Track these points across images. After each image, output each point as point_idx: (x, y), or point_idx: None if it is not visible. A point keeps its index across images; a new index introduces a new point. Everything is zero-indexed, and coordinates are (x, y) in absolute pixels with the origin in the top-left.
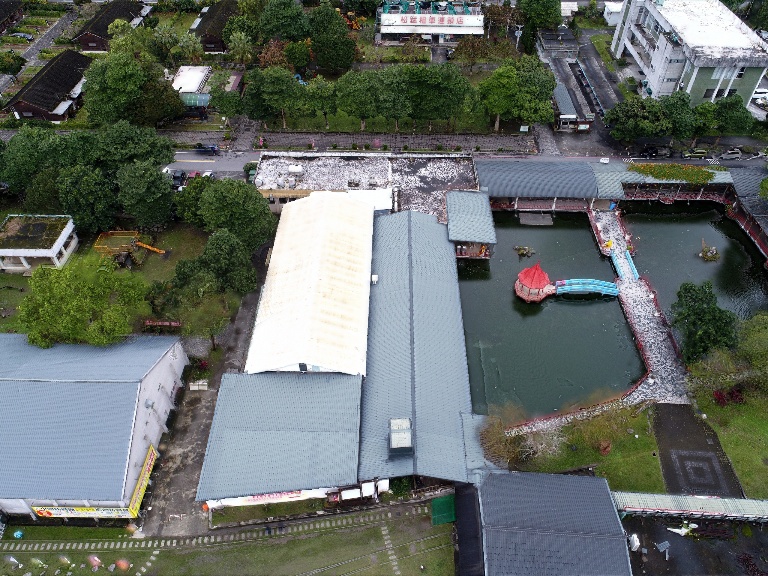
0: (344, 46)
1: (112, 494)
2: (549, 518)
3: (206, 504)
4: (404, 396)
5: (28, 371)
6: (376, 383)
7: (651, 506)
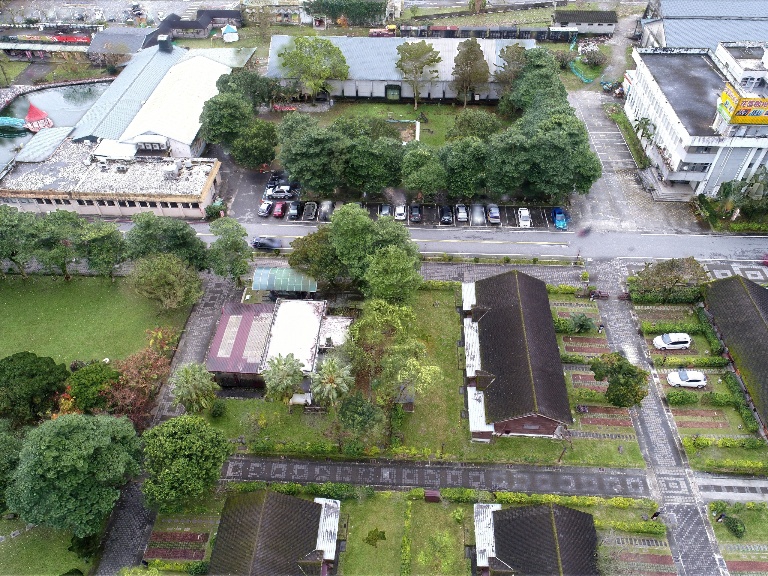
0: (1, 372)
1: None
2: (120, 38)
3: (257, 62)
4: (156, 60)
5: None
6: (167, 69)
7: (76, 47)
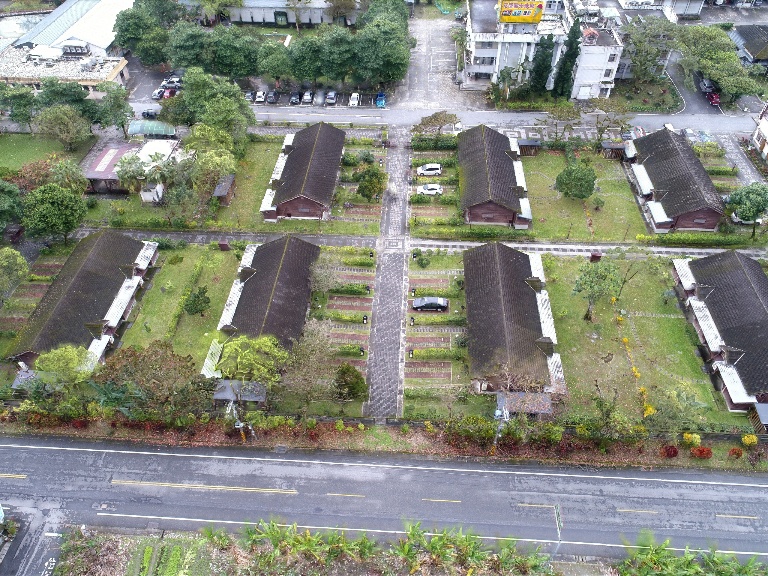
0: None
1: None
2: None
3: None
4: None
5: None
6: None
7: None
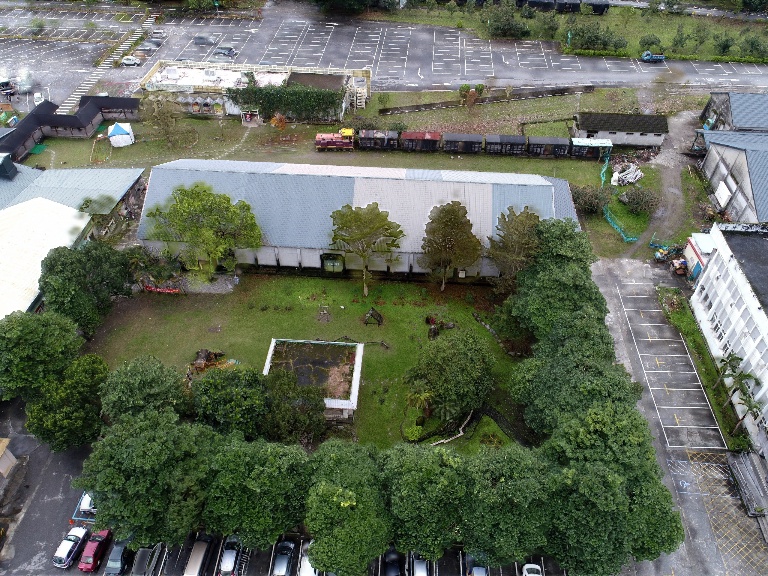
0: None
1: (188, 159)
2: None
3: None
4: None
5: (236, 183)
6: None
7: None
